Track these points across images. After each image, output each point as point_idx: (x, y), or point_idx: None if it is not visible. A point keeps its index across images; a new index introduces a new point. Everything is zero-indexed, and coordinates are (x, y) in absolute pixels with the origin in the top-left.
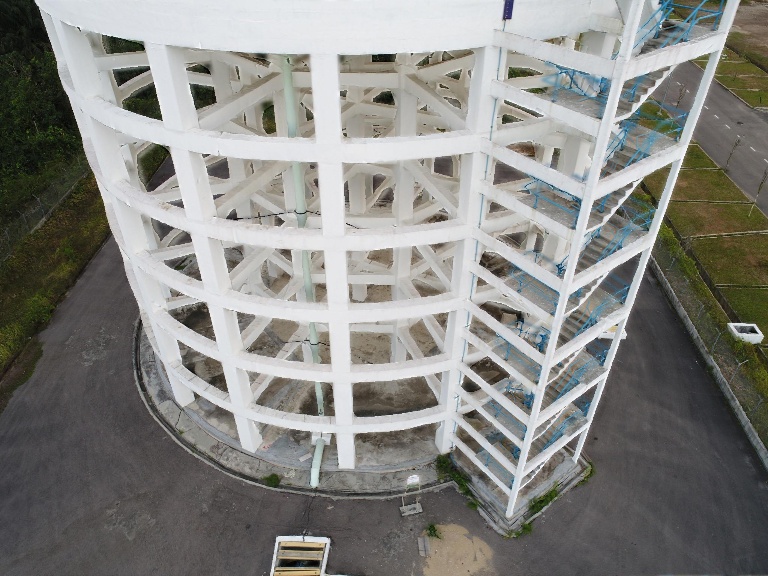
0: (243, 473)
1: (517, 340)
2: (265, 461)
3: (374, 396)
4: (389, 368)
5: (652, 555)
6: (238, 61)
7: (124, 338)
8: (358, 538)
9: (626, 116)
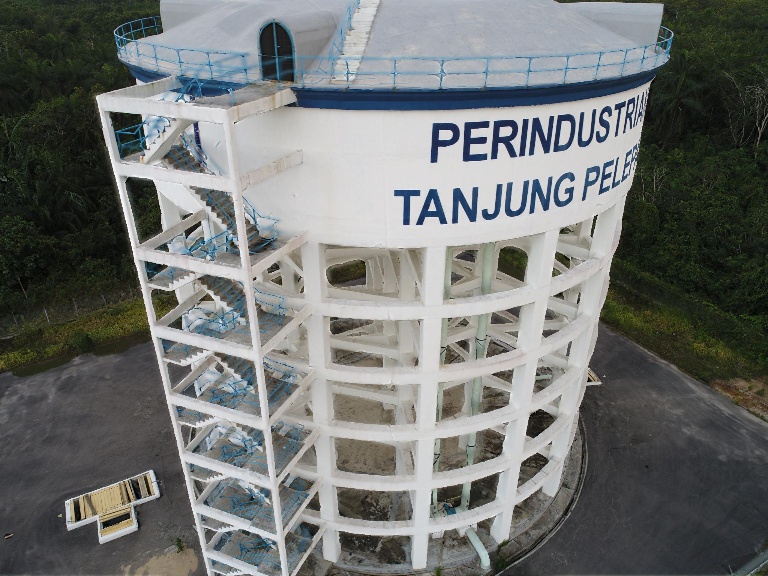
0: (195, 433)
1: None
2: None
3: None
4: None
5: None
6: None
7: None
8: (167, 510)
9: (166, 289)
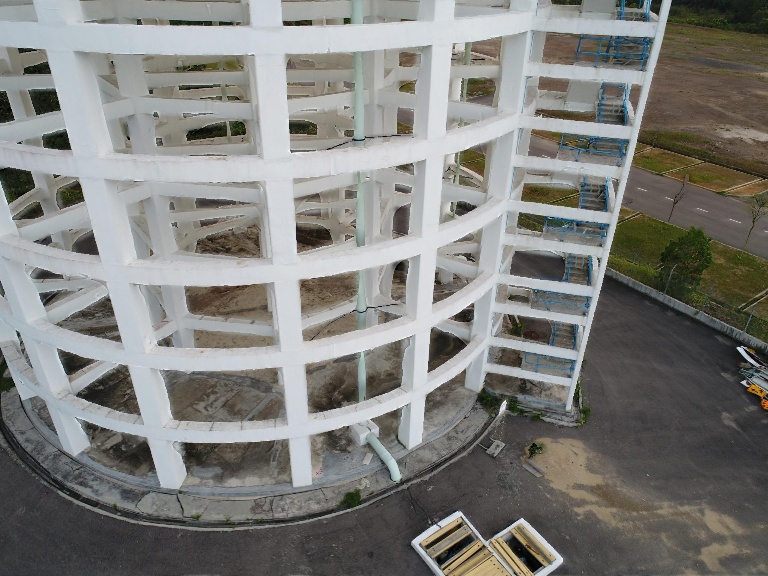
0: (312, 513)
1: (578, 211)
2: (327, 487)
3: (374, 379)
4: (458, 298)
5: (665, 384)
6: (170, 7)
7: (0, 467)
8: (479, 497)
9: None
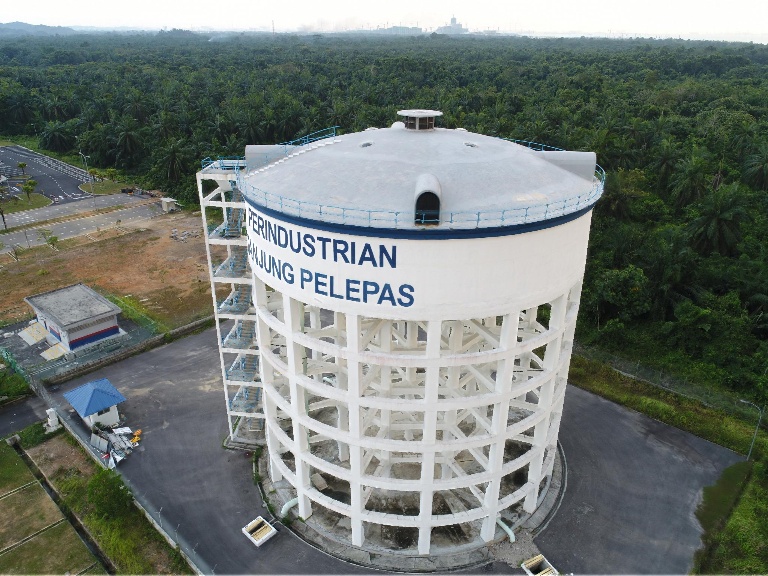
0: None
1: None
2: None
3: None
4: None
5: None
6: None
7: None
8: None
9: None
